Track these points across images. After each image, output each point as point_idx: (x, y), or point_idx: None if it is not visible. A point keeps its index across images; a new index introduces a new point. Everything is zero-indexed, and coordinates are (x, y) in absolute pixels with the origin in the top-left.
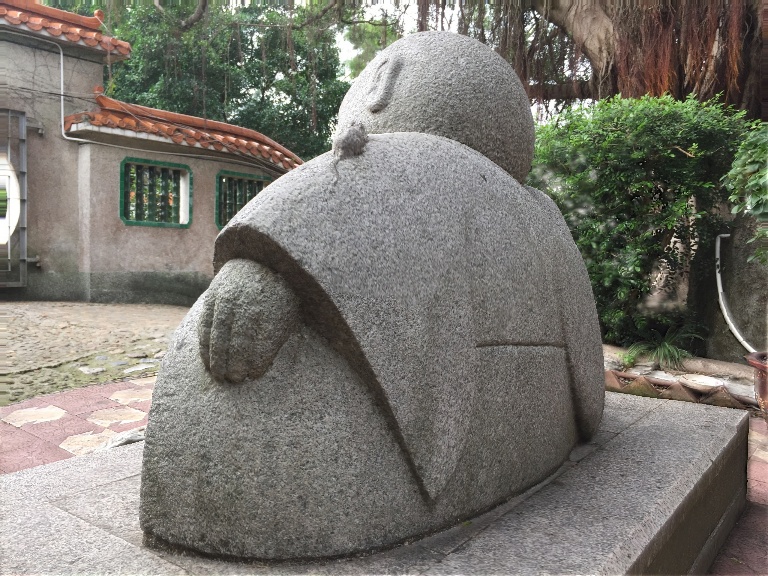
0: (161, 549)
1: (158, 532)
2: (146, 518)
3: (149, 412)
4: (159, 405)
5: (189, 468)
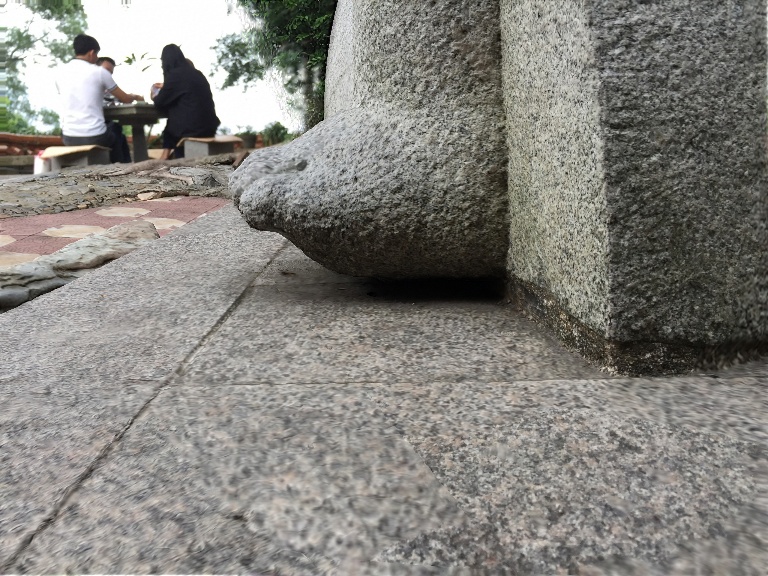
0: (683, 366)
1: (679, 329)
2: (641, 307)
3: (596, 51)
4: (630, 27)
5: (751, 162)
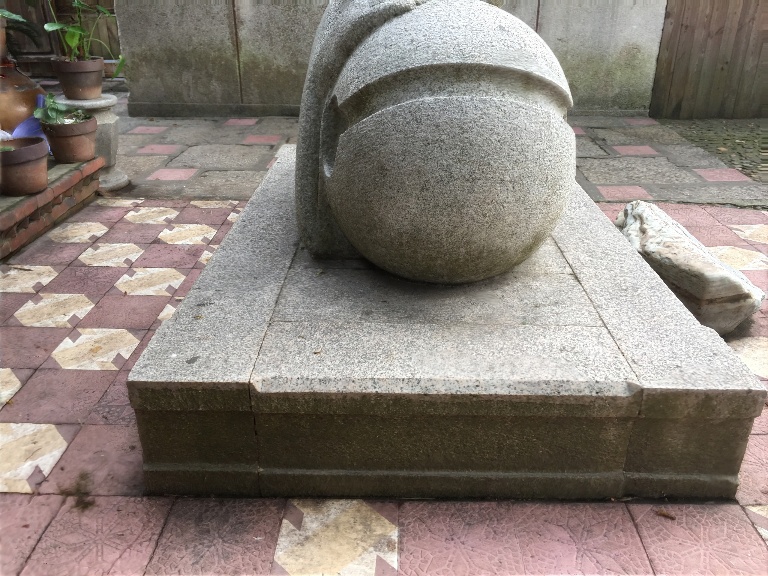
0: None
1: None
2: None
3: None
4: None
5: None
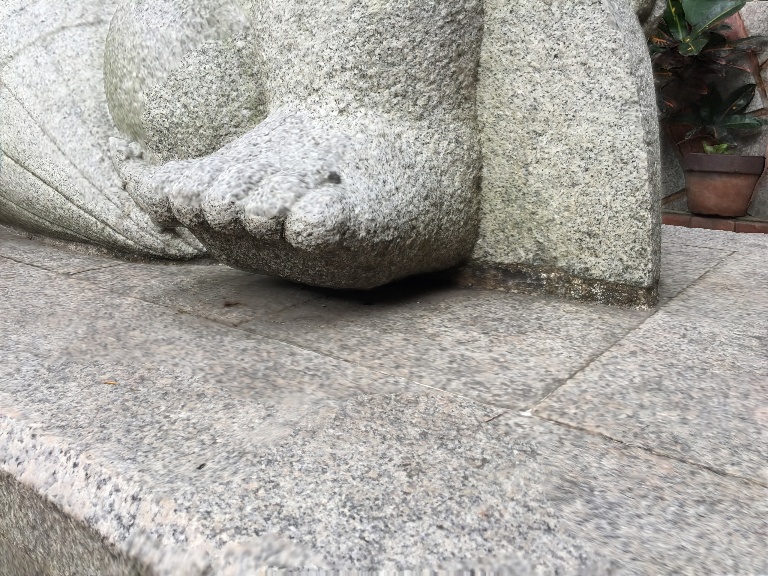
0: None
1: None
2: None
3: None
4: None
5: None
